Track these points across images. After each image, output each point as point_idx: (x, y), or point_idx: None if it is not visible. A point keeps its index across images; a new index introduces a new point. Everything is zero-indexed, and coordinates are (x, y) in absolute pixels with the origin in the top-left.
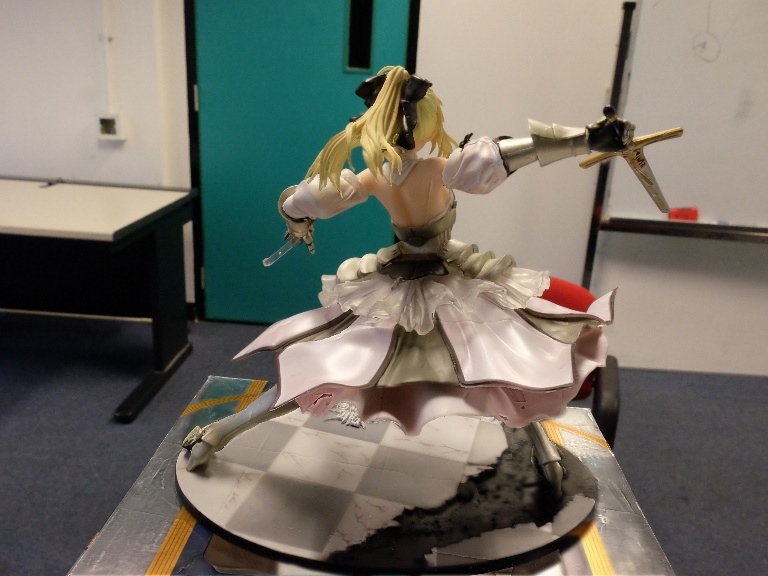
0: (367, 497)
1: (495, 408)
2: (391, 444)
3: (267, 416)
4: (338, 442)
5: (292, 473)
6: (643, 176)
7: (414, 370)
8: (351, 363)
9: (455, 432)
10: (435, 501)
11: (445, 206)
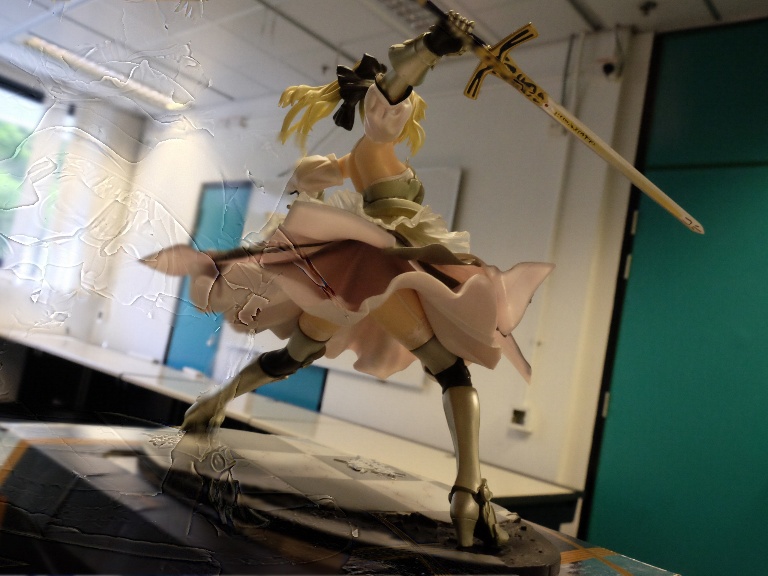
0: (1, 450)
1: None
2: (149, 459)
3: (2, 333)
4: (107, 439)
5: (4, 424)
6: None
7: None
8: None
9: (243, 485)
10: (45, 479)
11: (156, 50)
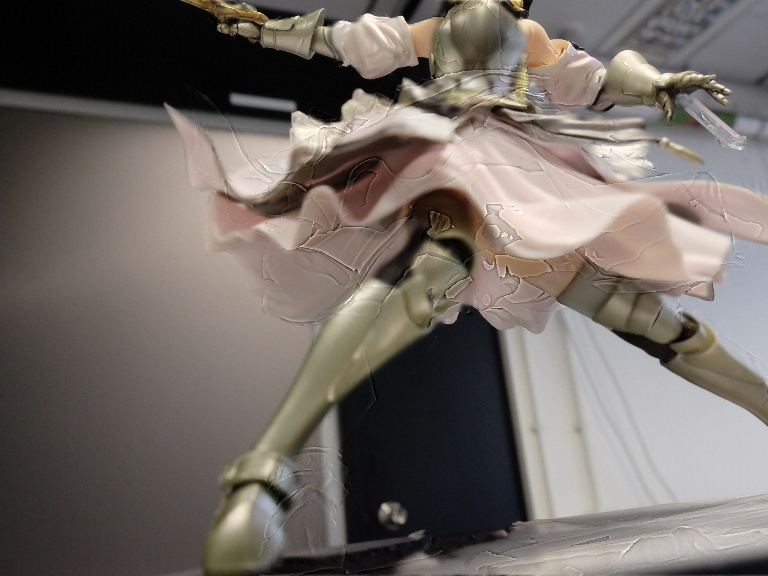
0: None
1: None
2: (754, 512)
3: None
4: None
5: (747, 499)
6: None
7: None
8: (469, 278)
9: None
10: None
11: None
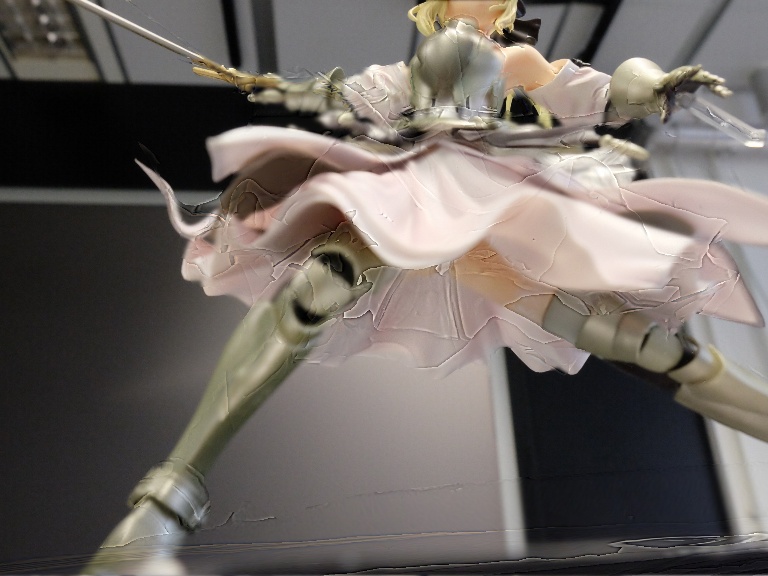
0: None
1: (338, 353)
2: (658, 556)
3: None
4: None
5: None
6: (158, 26)
7: (425, 319)
8: None
9: None
10: None
11: None
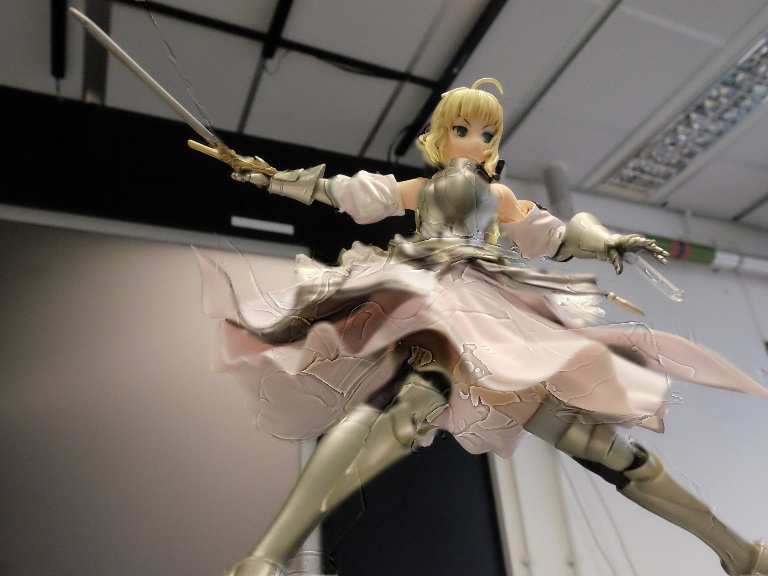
0: None
1: None
2: None
3: None
4: None
5: None
6: (203, 113)
7: (386, 402)
8: None
9: None
10: None
11: None
